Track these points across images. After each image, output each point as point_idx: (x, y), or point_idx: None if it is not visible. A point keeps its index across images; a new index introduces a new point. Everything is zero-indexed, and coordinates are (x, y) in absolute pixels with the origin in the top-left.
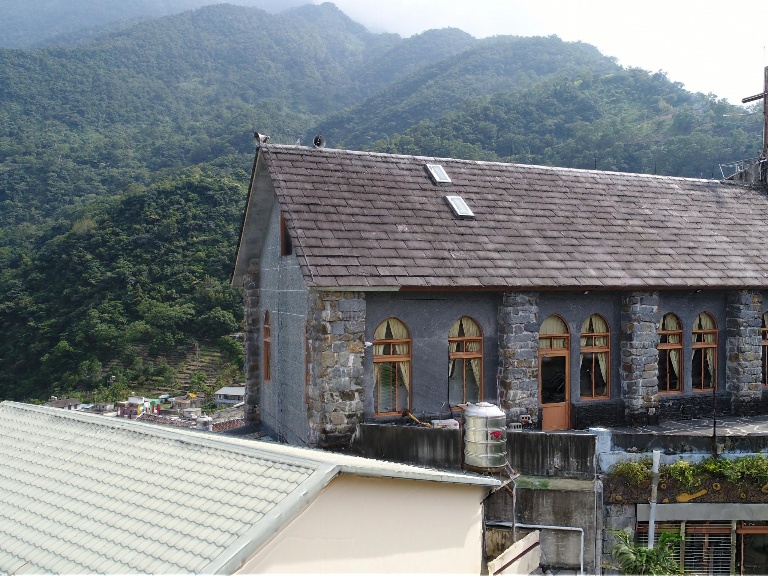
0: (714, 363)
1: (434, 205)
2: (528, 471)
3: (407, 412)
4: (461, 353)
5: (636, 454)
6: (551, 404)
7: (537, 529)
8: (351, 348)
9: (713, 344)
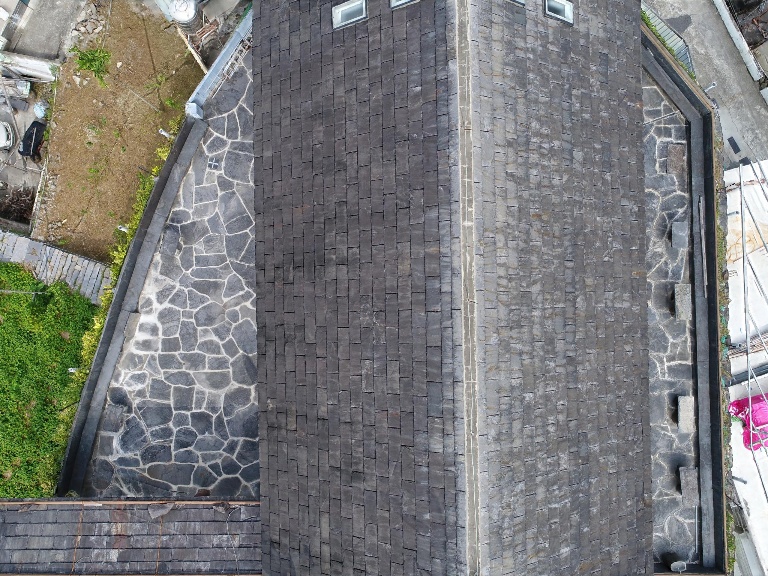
0: None
1: None
2: None
3: None
4: None
5: None
6: None
7: None
8: None
9: None
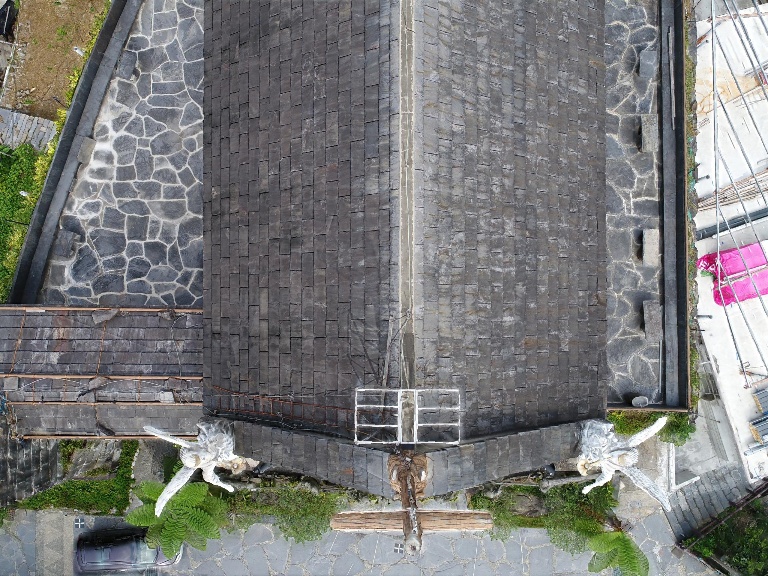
0: None
1: None
2: None
3: None
4: None
5: None
6: None
7: None
8: None
9: None
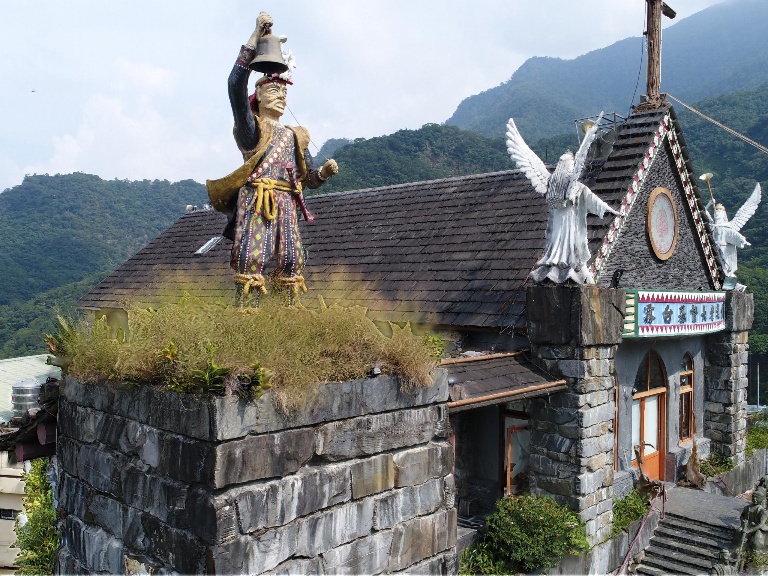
0: None
1: None
2: None
3: None
4: None
5: None
6: None
7: None
8: None
9: None
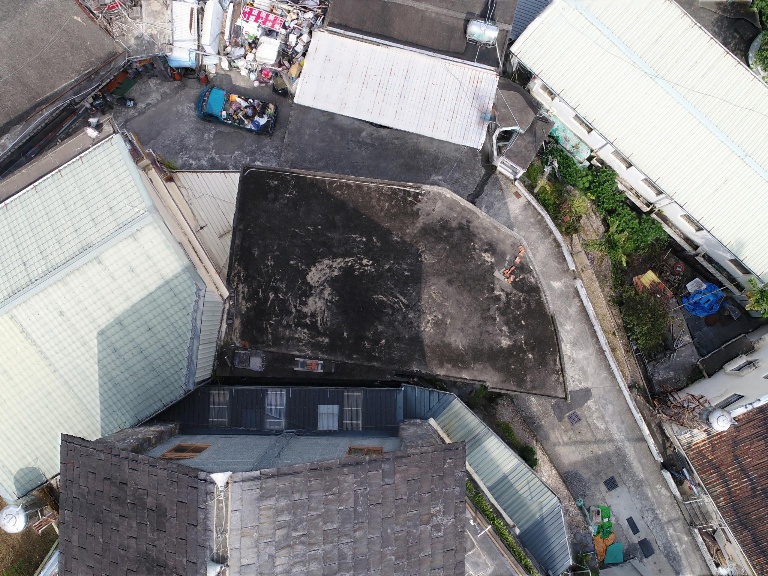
0: None
1: None
2: None
3: None
4: None
5: None
6: None
7: None
8: None
9: None
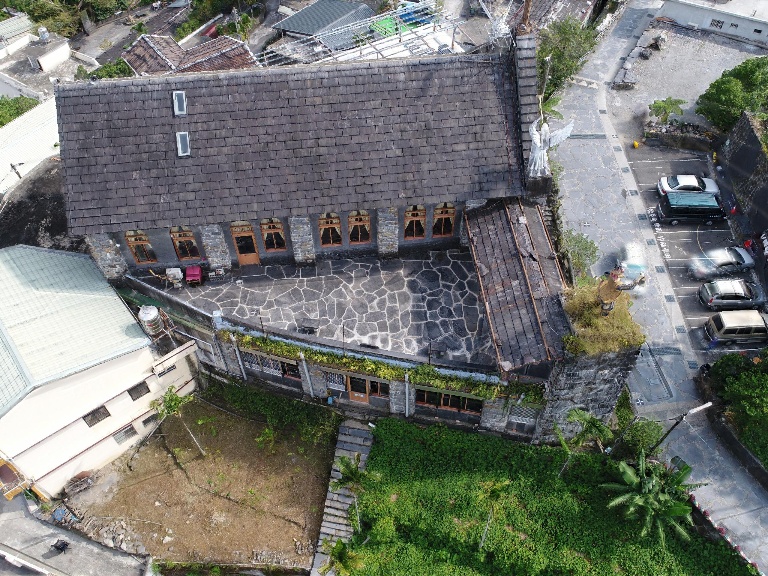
0: (369, 230)
1: (166, 144)
2: (192, 317)
3: (148, 270)
4: (182, 238)
5: (232, 327)
6: (246, 254)
7: (194, 339)
8: (107, 251)
9: (367, 222)
